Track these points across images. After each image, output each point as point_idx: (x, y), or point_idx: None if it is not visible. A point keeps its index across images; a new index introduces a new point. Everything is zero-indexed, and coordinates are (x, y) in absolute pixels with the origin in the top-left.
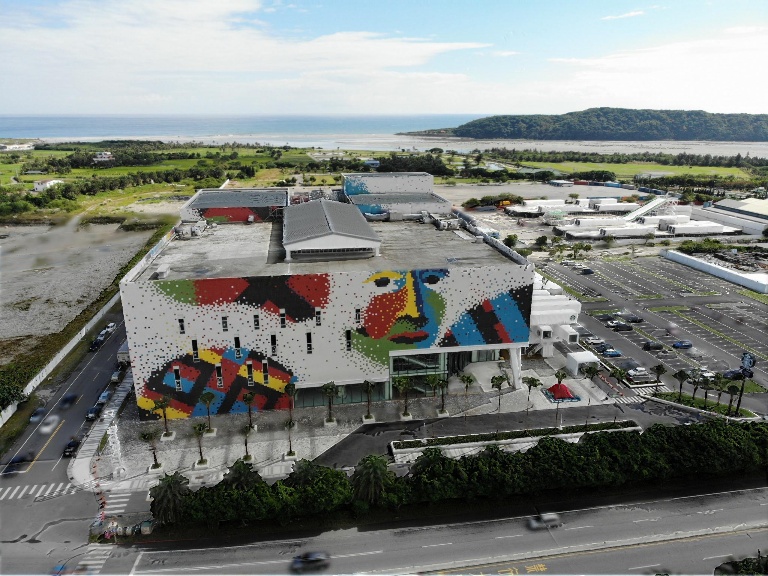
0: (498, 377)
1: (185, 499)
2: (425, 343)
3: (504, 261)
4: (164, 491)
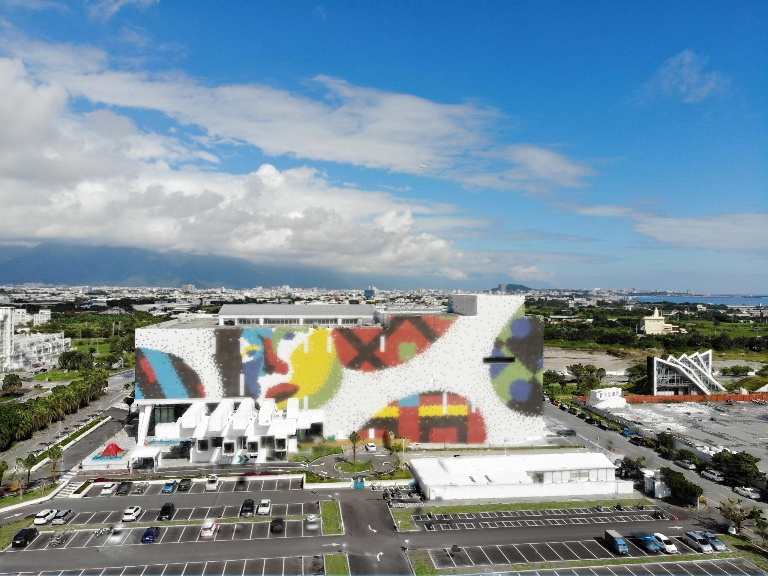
0: None
1: None
2: None
3: None
4: None
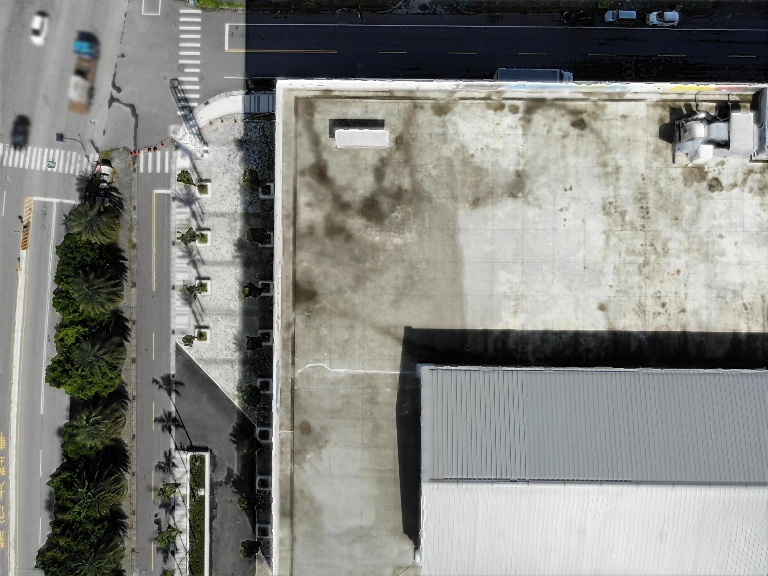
0: None
1: (71, 238)
2: None
3: None
4: (70, 218)
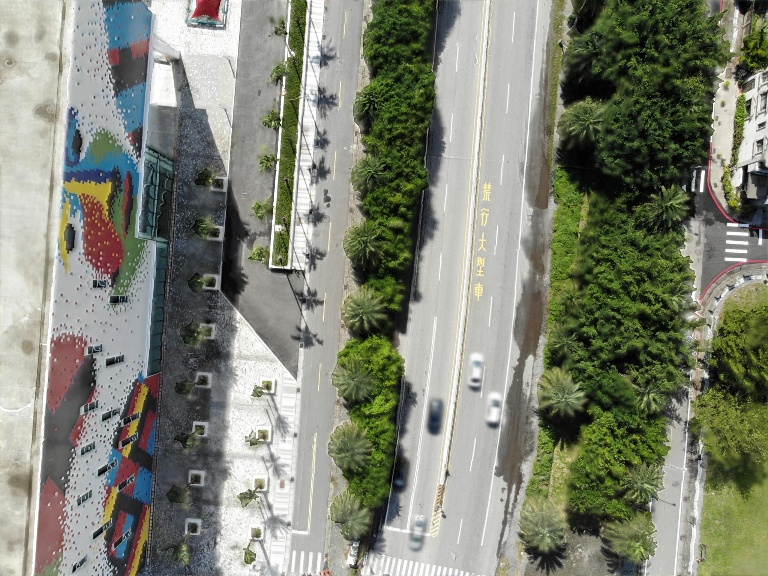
0: (271, 118)
1: (371, 503)
2: (134, 180)
3: None
4: (365, 526)
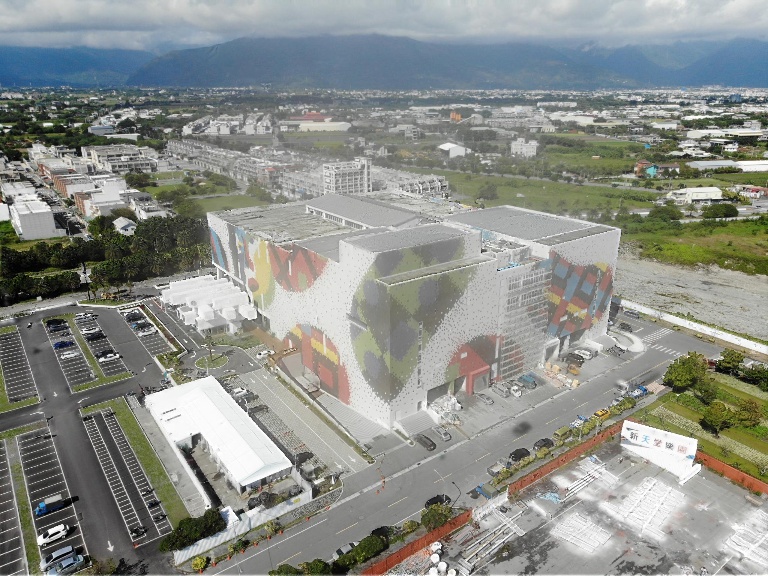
0: None
1: None
2: None
3: (227, 219)
4: None
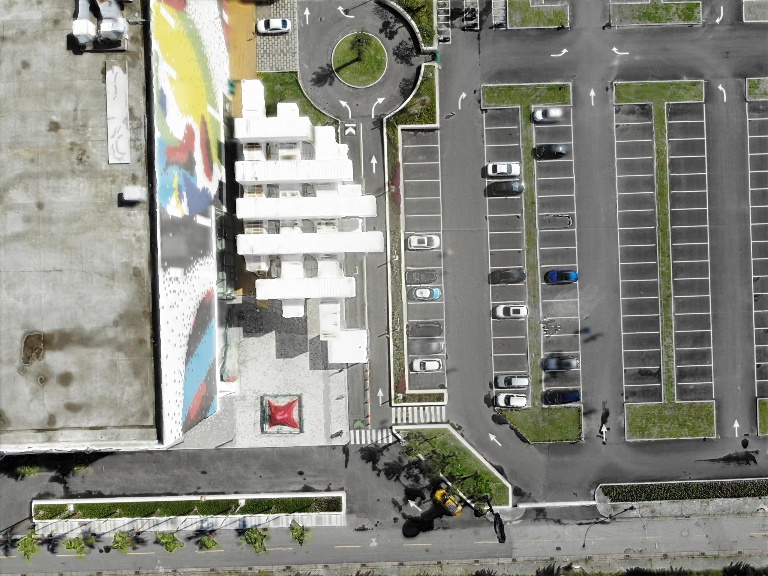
0: None
1: None
2: None
3: (135, 370)
4: None
